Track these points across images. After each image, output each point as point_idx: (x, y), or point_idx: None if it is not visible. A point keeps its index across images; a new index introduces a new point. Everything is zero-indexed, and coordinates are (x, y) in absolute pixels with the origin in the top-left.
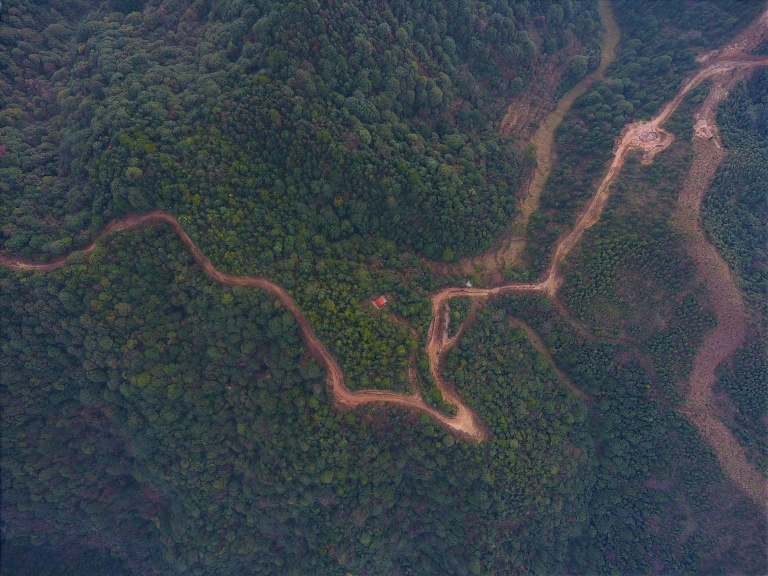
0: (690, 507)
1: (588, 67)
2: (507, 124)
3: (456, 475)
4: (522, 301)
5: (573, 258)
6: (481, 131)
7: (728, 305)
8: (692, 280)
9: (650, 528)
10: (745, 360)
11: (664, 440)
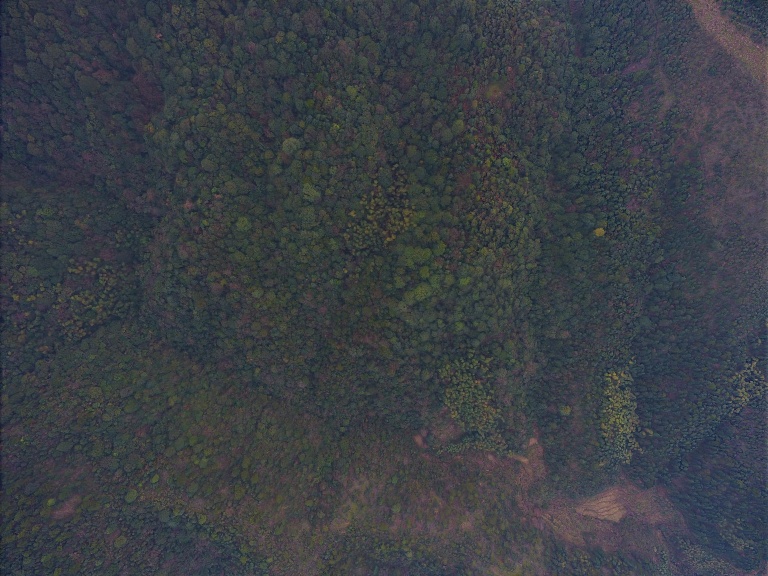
0: (667, 79)
1: None
2: None
3: (439, 15)
4: None
5: None
6: None
7: None
8: None
9: (629, 113)
10: None
11: (642, 10)
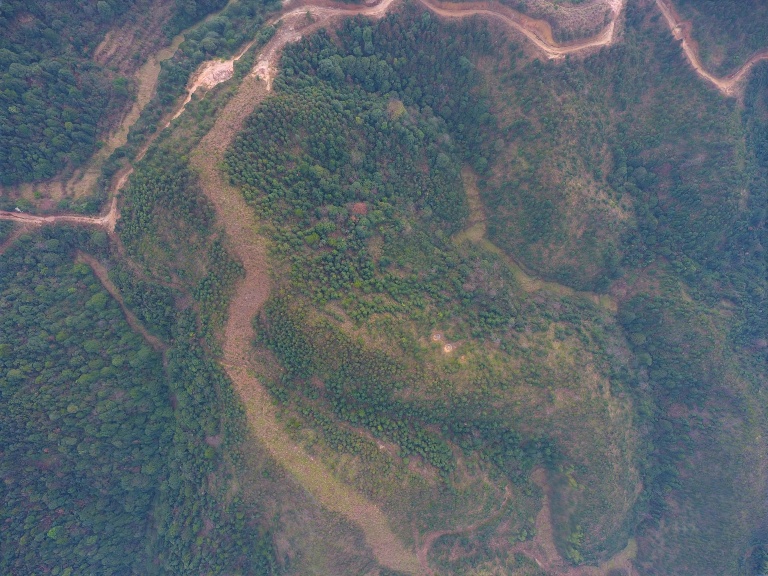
0: None
1: (201, 3)
2: (103, 52)
3: None
4: (78, 233)
5: (124, 192)
6: (62, 54)
7: (248, 252)
8: (214, 222)
9: (204, 485)
10: (272, 313)
11: (209, 393)
